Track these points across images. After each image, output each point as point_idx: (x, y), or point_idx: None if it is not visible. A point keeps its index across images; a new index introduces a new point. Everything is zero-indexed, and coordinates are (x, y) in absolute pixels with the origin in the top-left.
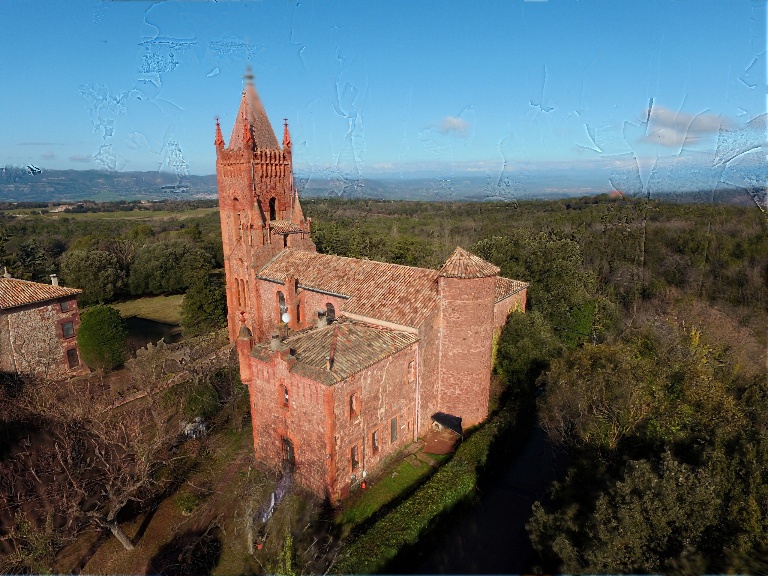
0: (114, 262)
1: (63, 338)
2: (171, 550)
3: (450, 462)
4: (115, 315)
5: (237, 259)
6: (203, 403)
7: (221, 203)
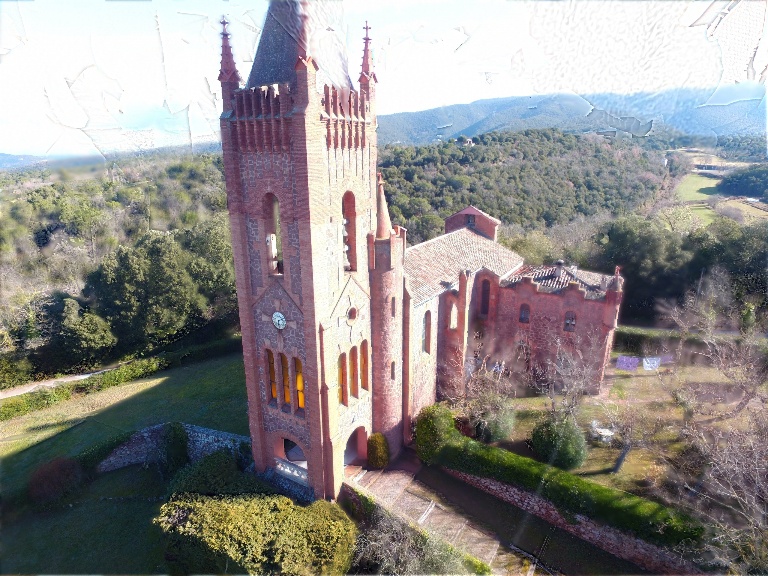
0: None
1: None
2: (711, 399)
3: None
4: None
5: (347, 313)
6: None
7: (316, 209)
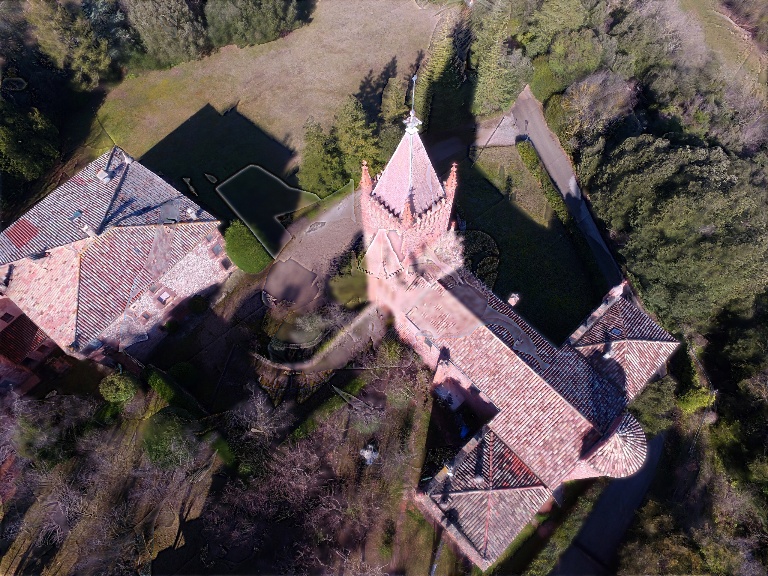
0: (186, 11)
1: (216, 256)
2: None
3: (547, 548)
4: None
5: None
6: (371, 429)
7: None
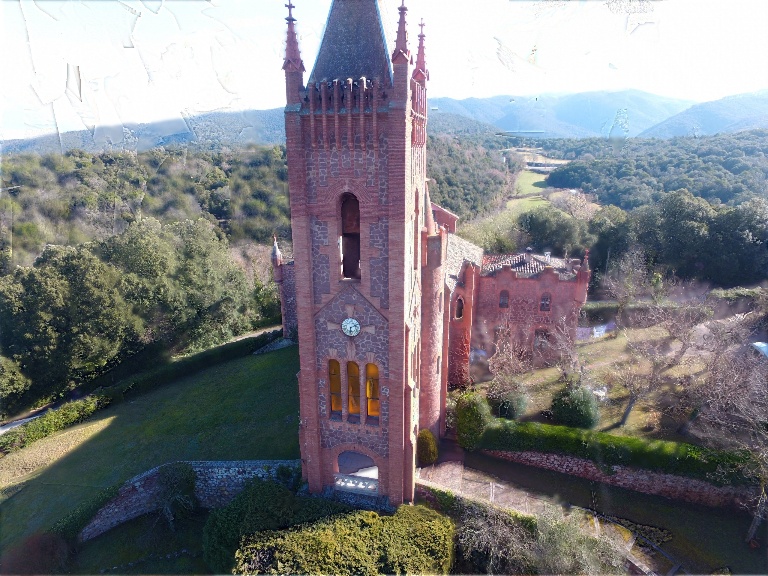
0: None
1: None
2: None
3: None
4: None
5: None
6: None
7: (407, 207)
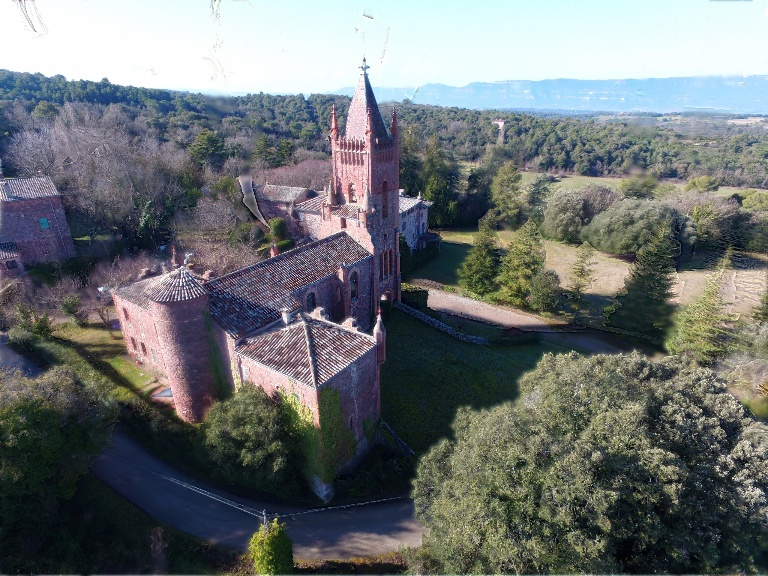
0: (578, 208)
1: None
2: None
3: (114, 384)
4: None
5: None
6: None
7: None
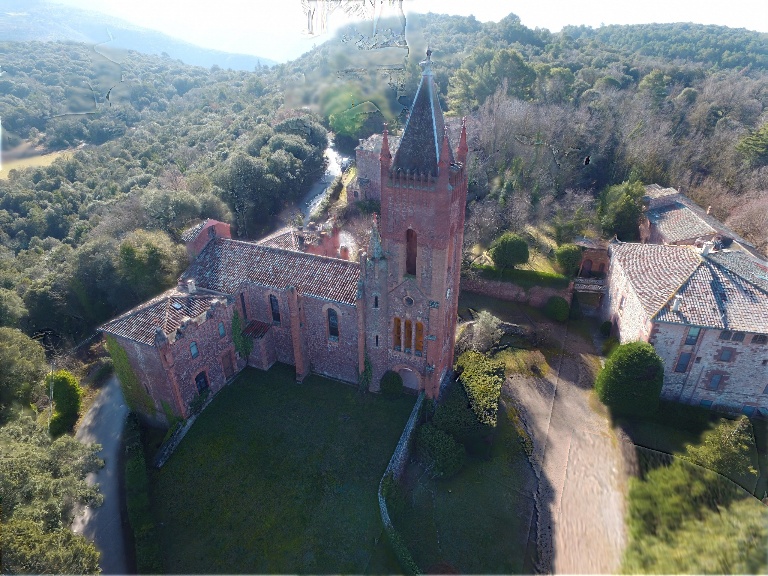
0: None
1: None
2: None
3: None
4: (624, 356)
5: None
6: None
7: None
